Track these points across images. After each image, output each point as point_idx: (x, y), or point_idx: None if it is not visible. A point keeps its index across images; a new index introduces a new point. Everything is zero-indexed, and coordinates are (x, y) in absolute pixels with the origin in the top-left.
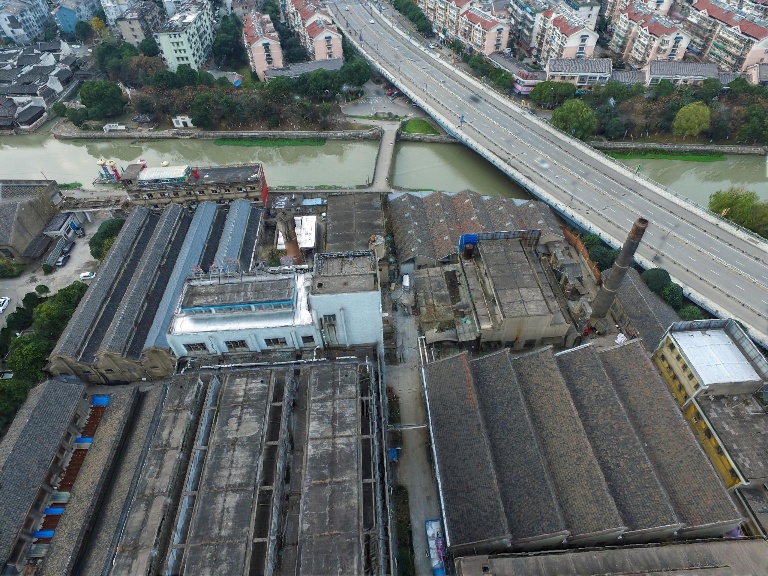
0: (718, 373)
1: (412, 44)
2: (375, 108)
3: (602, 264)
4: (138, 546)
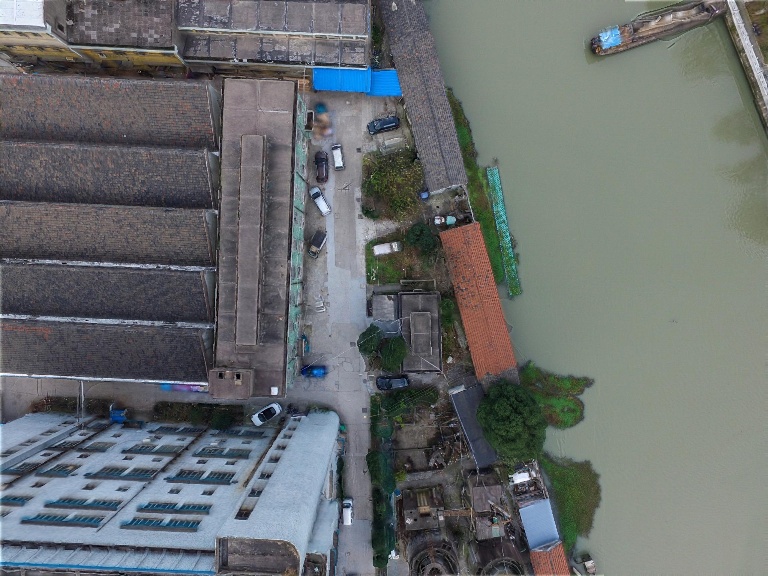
0: None
1: None
2: None
3: None
4: None
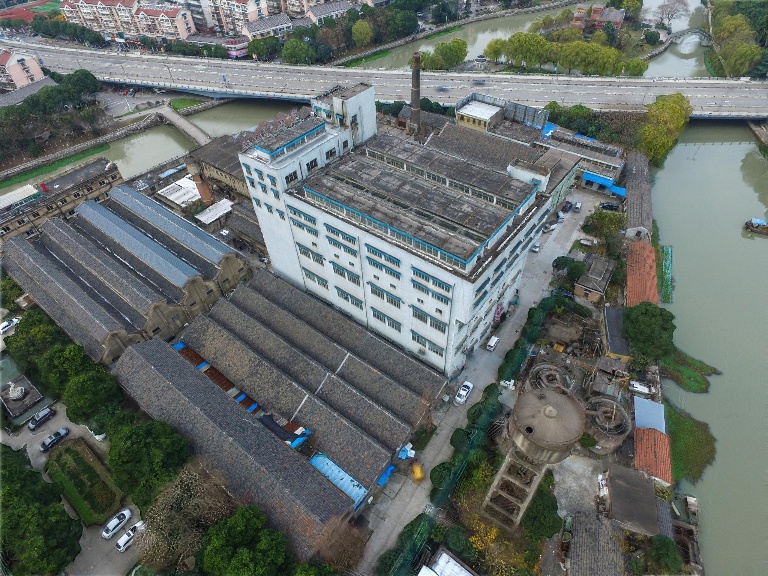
0: (488, 114)
1: (98, 54)
2: (125, 107)
3: (394, 113)
4: (395, 217)
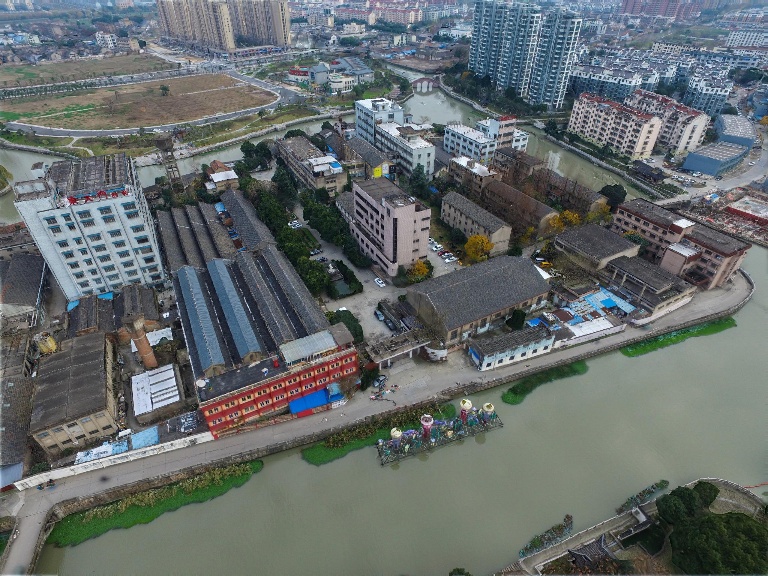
0: None
1: None
2: None
3: None
4: None
